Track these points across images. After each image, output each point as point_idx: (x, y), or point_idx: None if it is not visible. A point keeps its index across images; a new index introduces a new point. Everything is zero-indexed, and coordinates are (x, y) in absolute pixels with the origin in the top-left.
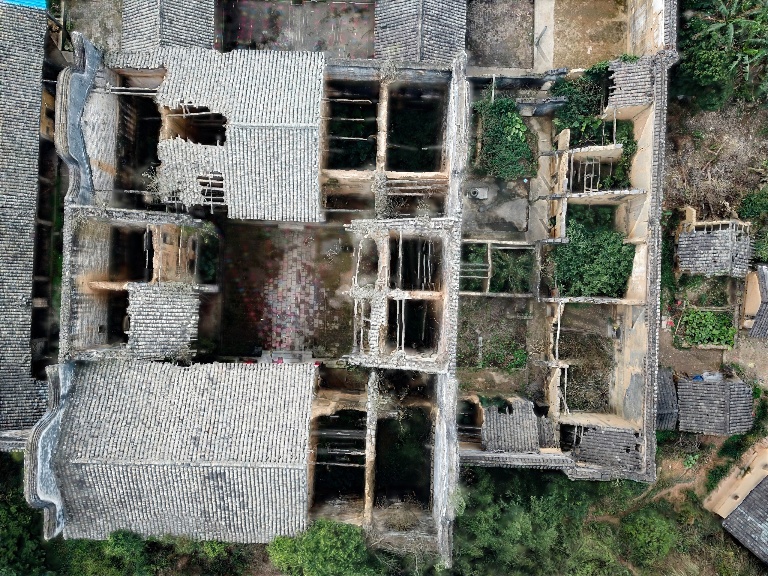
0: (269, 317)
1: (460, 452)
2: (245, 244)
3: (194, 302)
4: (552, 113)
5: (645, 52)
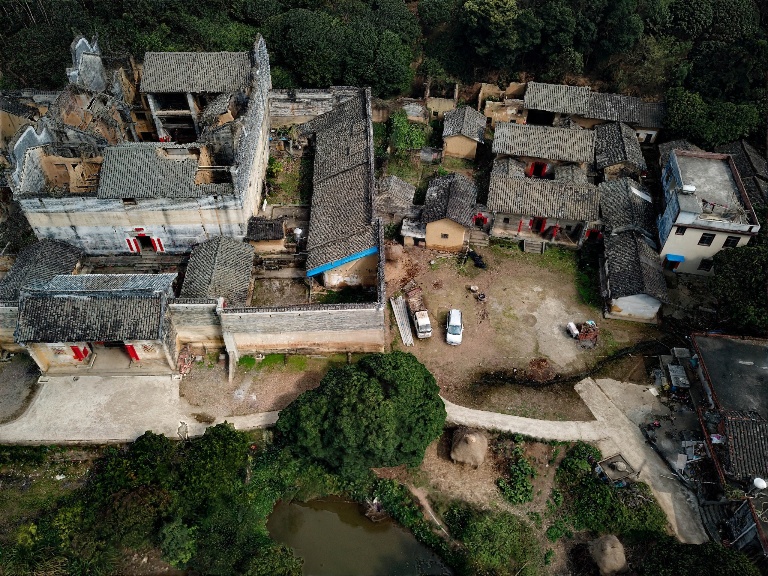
0: None
1: None
2: None
3: None
4: None
5: None
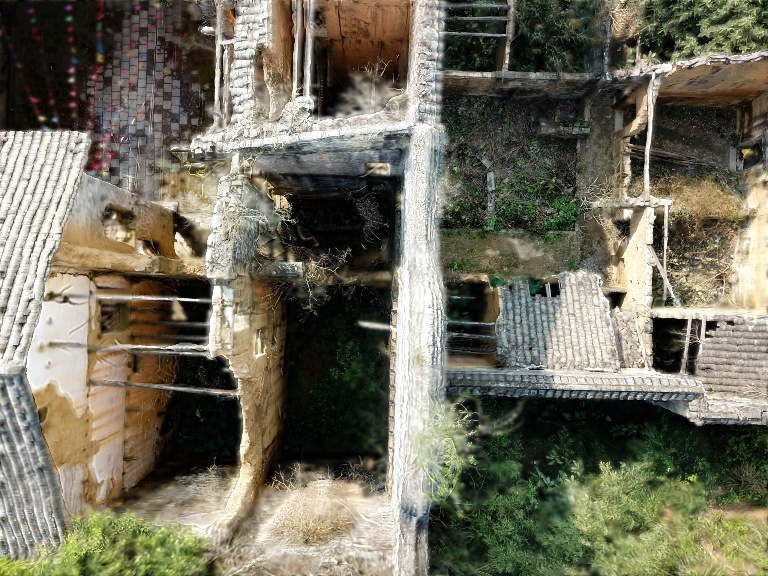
0: (97, 139)
1: (452, 370)
2: (51, 3)
3: None
4: None
5: None
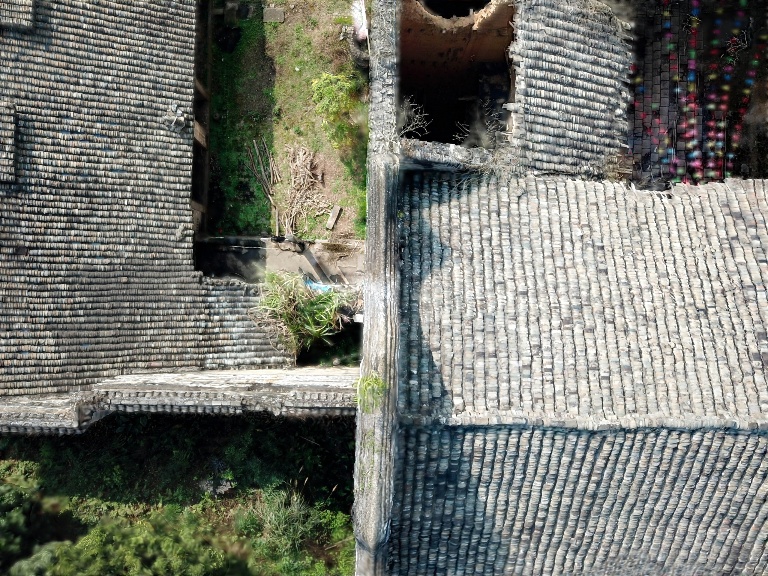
0: None
1: None
2: None
3: (626, 58)
4: None
5: None
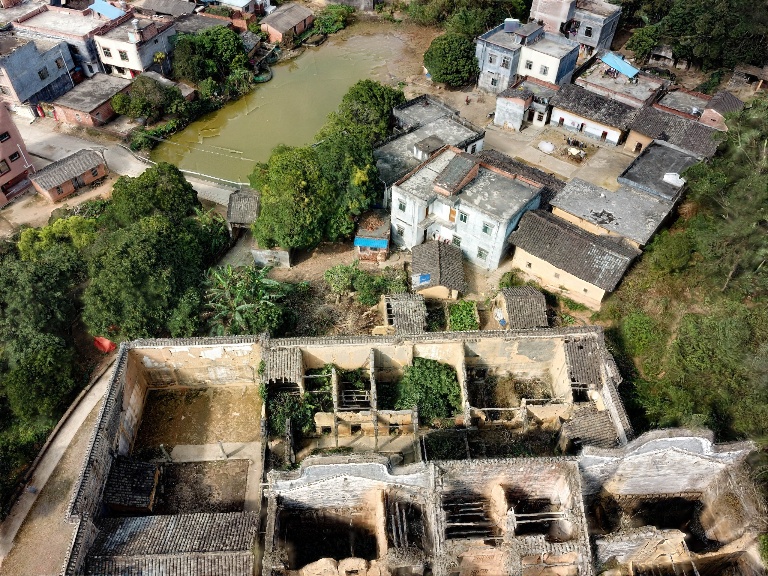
0: None
1: None
2: None
3: None
4: (295, 436)
5: (249, 365)
